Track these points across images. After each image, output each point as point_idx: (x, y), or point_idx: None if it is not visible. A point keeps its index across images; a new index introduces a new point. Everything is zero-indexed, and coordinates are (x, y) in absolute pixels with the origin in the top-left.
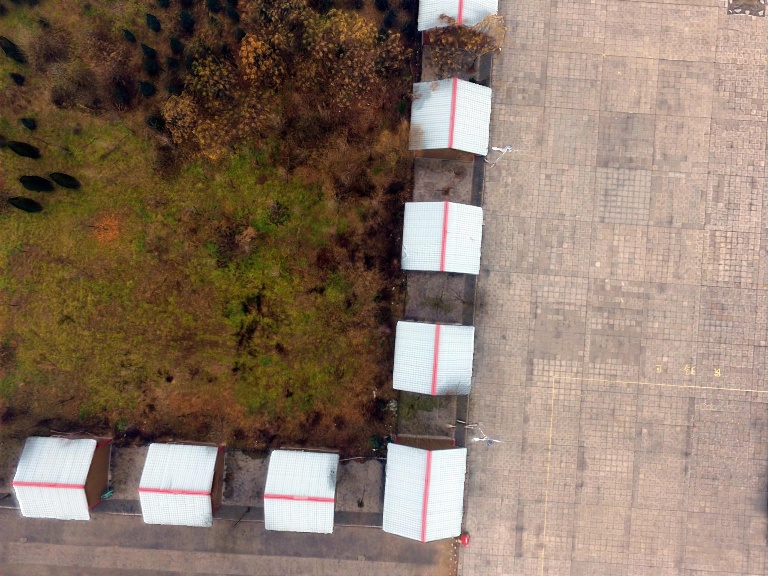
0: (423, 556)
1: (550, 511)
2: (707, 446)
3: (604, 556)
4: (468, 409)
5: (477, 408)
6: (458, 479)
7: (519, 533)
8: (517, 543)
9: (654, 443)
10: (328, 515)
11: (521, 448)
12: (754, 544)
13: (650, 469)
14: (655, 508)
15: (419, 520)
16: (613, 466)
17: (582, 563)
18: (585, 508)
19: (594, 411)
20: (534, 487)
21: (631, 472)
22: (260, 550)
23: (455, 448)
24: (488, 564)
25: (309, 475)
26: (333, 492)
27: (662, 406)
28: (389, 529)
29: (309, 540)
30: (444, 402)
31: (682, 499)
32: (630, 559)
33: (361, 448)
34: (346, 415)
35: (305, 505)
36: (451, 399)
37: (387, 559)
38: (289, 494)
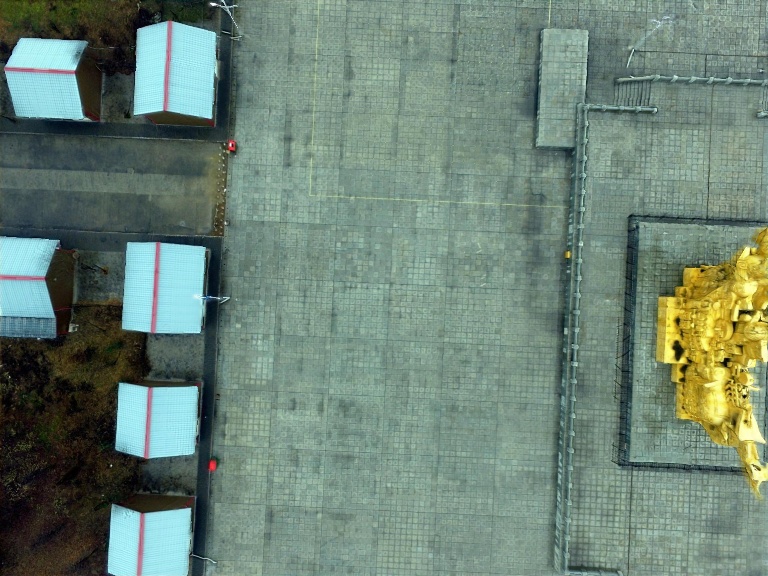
0: (192, 168)
1: (317, 121)
2: (473, 52)
3: (372, 163)
4: (233, 21)
5: (243, 20)
6: (206, 61)
7: (287, 143)
8: (285, 153)
9: (420, 51)
10: (73, 92)
11: (287, 59)
12: (520, 147)
13: (416, 77)
14: (422, 115)
15: (161, 91)
16: (380, 75)
17: (350, 171)
18: (352, 117)
19: (360, 20)
20: (301, 97)
21: (397, 80)
22: (29, 164)
23: (201, 28)
24: (257, 174)
25: (53, 54)
26: (75, 66)
27: (428, 14)
28: (138, 111)
29: (78, 153)
30: (208, 13)
31: (448, 105)
32: (397, 165)
33: (126, 60)
34: (111, 28)
35: (47, 78)
36: (215, 10)
37: (156, 171)
38: (30, 67)
